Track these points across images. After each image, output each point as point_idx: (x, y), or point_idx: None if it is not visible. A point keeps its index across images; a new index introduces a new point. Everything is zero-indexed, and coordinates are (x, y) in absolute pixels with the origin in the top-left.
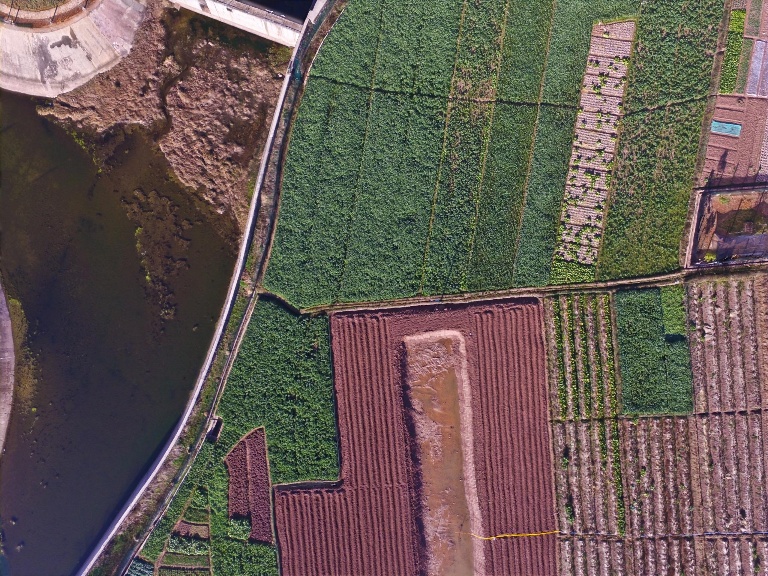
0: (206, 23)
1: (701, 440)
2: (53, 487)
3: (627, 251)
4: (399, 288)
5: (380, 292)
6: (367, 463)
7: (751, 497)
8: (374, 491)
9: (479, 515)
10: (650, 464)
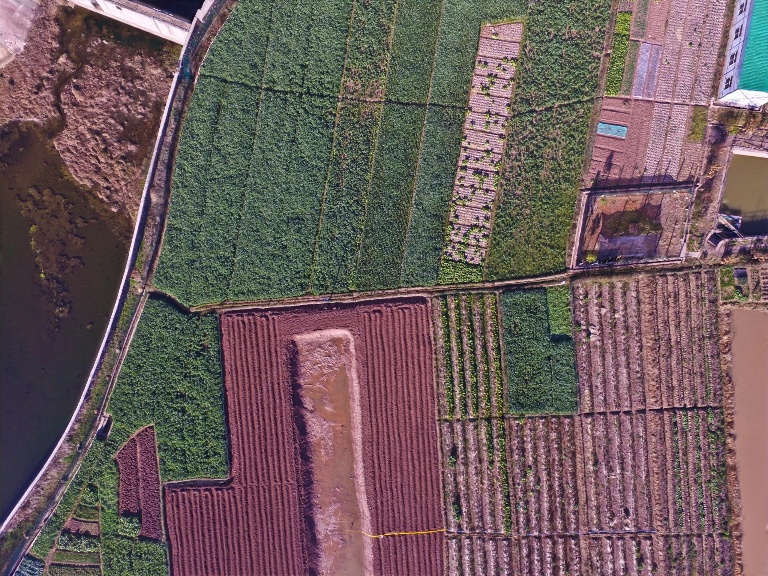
0: (101, 21)
1: (586, 439)
2: None
3: (514, 251)
4: (288, 287)
5: (269, 291)
6: (256, 461)
7: (635, 496)
8: (263, 489)
9: (368, 513)
10: (536, 463)
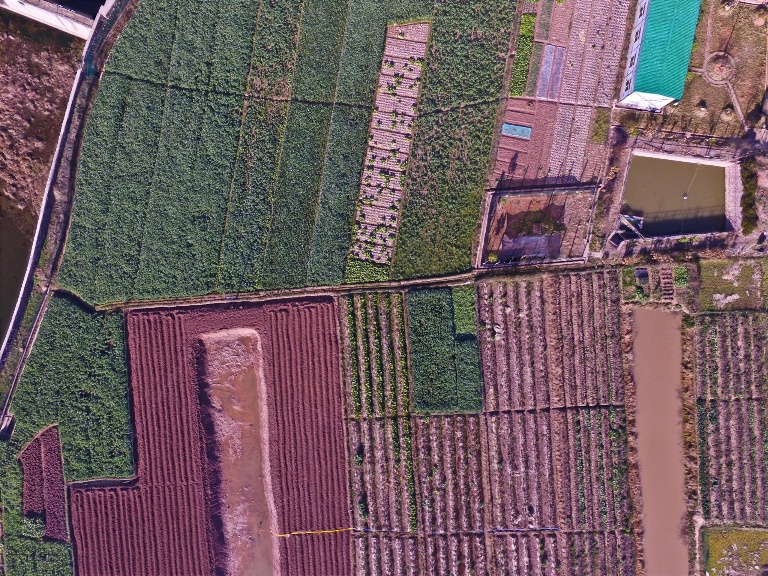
0: (7, 16)
1: (491, 438)
2: None
3: (421, 251)
4: (193, 286)
5: (174, 289)
6: (162, 461)
7: (539, 494)
8: (168, 489)
9: (275, 512)
10: (442, 462)
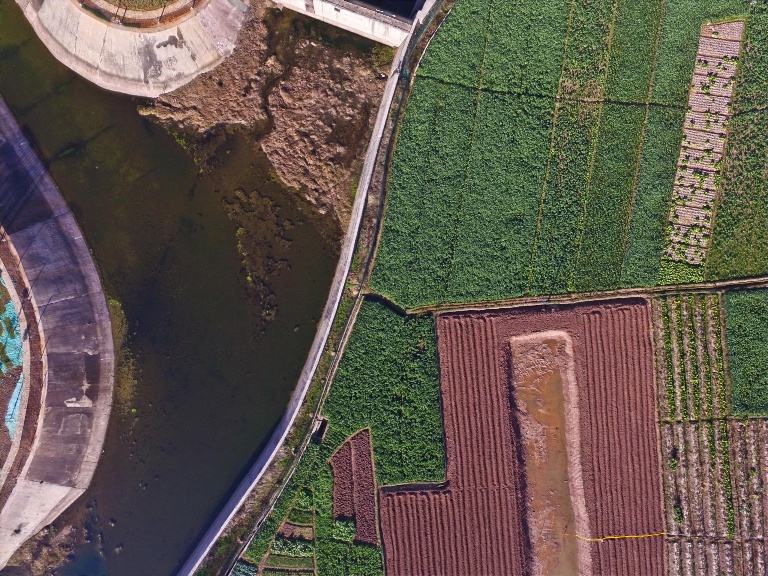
0: (308, 23)
1: None
2: (152, 488)
3: (736, 251)
4: (507, 288)
5: (488, 292)
6: (473, 464)
7: None
8: (481, 492)
9: (586, 516)
10: (759, 465)
